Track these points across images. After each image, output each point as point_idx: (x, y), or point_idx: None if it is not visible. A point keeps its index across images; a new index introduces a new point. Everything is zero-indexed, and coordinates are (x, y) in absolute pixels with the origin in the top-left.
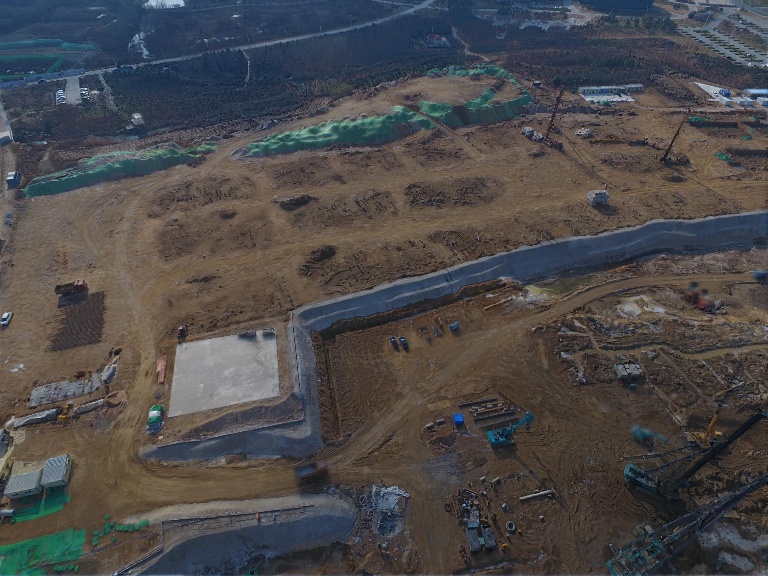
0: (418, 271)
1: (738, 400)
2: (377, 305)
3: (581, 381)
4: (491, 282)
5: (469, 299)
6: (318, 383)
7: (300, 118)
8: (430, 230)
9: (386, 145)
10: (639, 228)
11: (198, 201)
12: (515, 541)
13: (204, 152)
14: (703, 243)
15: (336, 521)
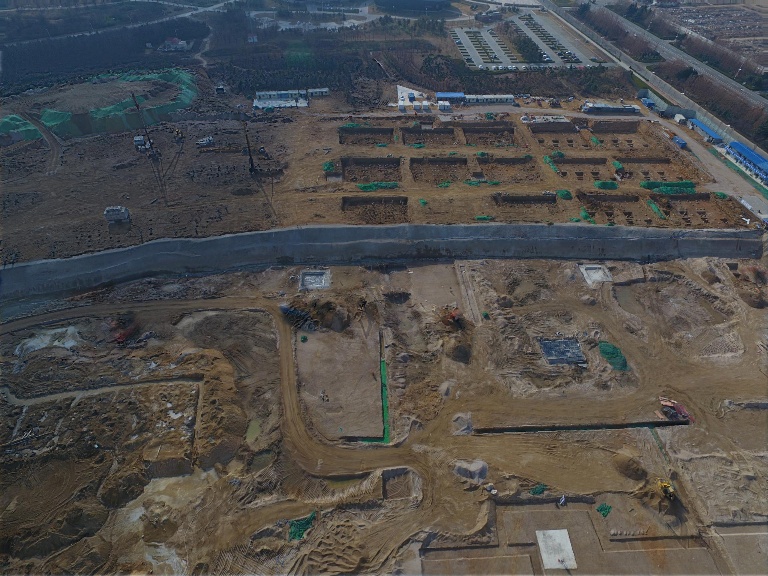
0: None
1: None
2: None
3: None
4: None
5: None
6: None
7: None
8: None
9: None
10: (129, 249)
11: None
12: None
13: None
14: (207, 264)
15: None
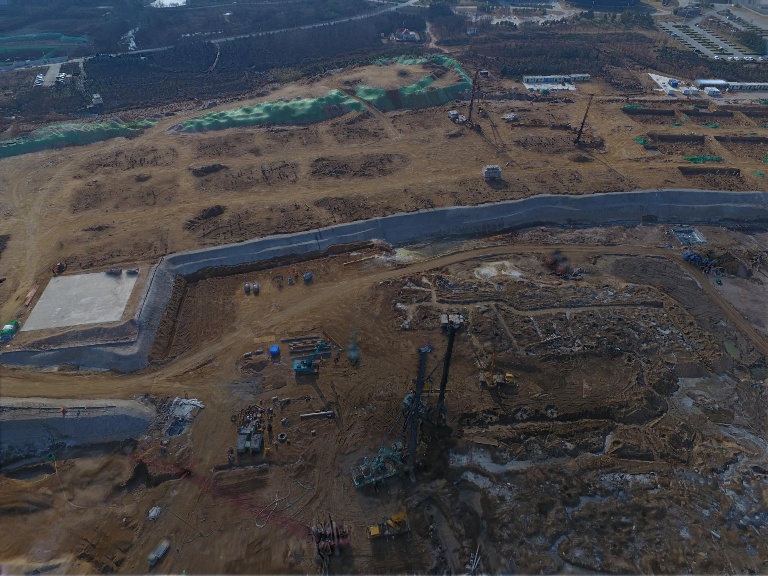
0: (291, 229)
1: (547, 351)
2: (244, 256)
3: (404, 327)
4: (360, 242)
5: (333, 256)
6: (164, 315)
7: (240, 99)
8: (319, 196)
9: (313, 125)
10: (522, 201)
11: (121, 167)
12: (281, 448)
13: (143, 127)
14: (587, 218)
15: (132, 421)
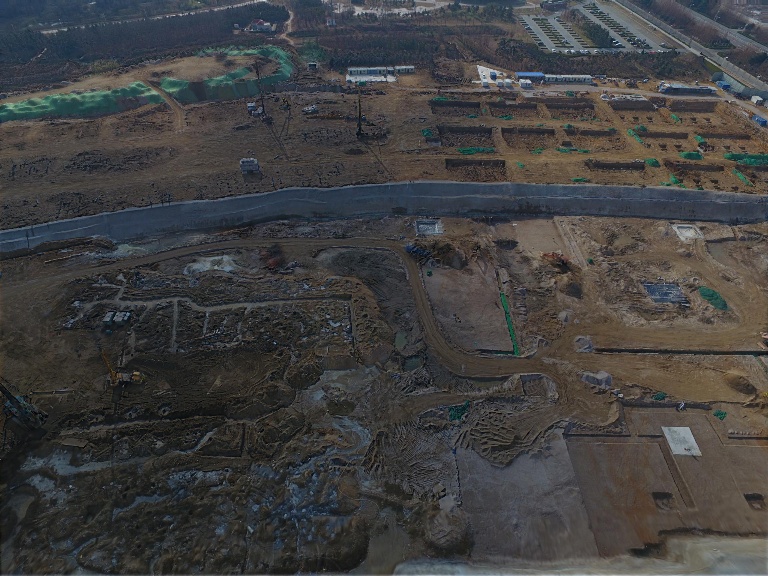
0: (2, 226)
1: (199, 347)
2: None
3: (65, 326)
4: (77, 239)
5: (40, 253)
6: None
7: (33, 91)
8: (57, 192)
9: (102, 117)
10: (266, 194)
11: None
12: None
13: None
14: (332, 211)
15: None
